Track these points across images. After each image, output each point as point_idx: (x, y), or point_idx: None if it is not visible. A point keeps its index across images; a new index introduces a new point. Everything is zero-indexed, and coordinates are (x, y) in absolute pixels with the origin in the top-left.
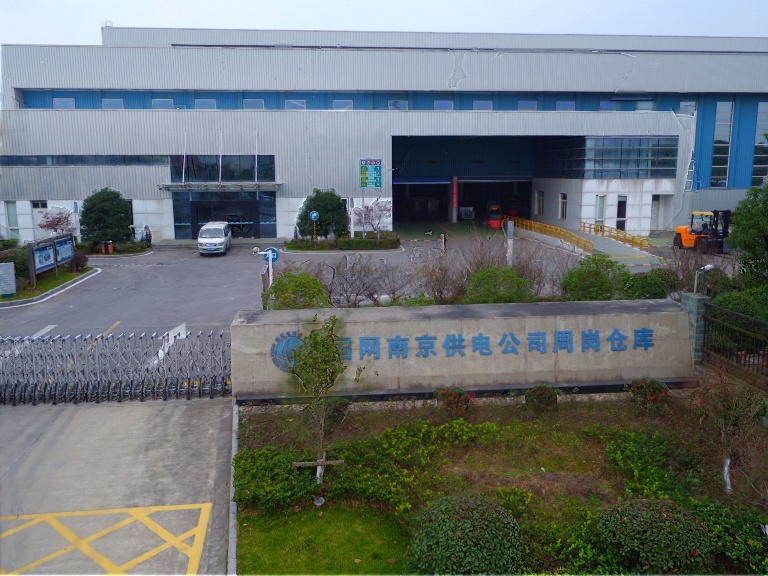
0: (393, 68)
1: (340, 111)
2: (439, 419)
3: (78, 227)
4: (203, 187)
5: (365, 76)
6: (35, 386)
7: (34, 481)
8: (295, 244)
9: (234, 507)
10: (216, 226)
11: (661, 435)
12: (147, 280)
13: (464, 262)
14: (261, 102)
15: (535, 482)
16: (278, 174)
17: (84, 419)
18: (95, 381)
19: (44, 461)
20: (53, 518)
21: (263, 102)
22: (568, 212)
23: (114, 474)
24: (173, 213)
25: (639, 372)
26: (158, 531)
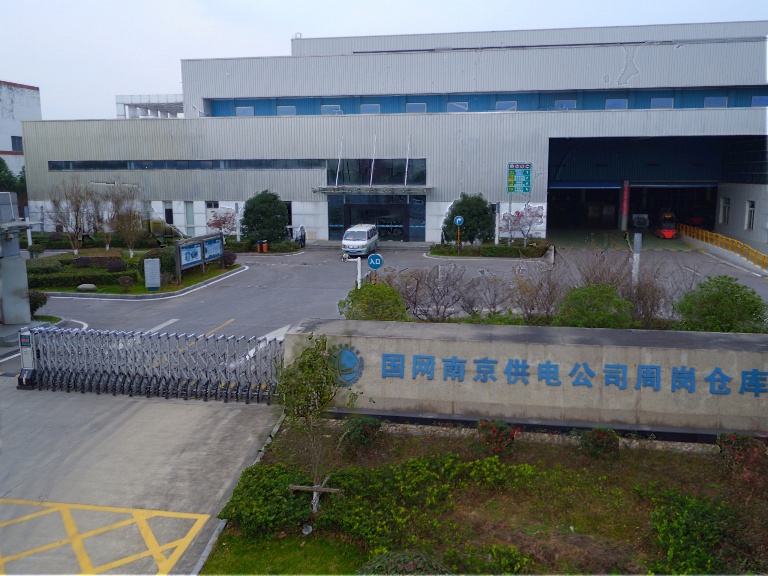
0: (561, 66)
1: (495, 113)
2: (473, 454)
3: (238, 226)
4: (355, 190)
5: (530, 76)
6: (117, 377)
7: (73, 470)
8: (438, 249)
9: (223, 523)
10: (360, 229)
11: (729, 507)
12: (282, 279)
13: (579, 277)
14: (424, 105)
15: (551, 543)
16: (429, 178)
17: (147, 413)
18: (168, 377)
19: (92, 451)
20: (68, 509)
21: (425, 105)
22: (755, 222)
23: (141, 472)
24: (328, 215)
25: (746, 422)
26: (147, 537)
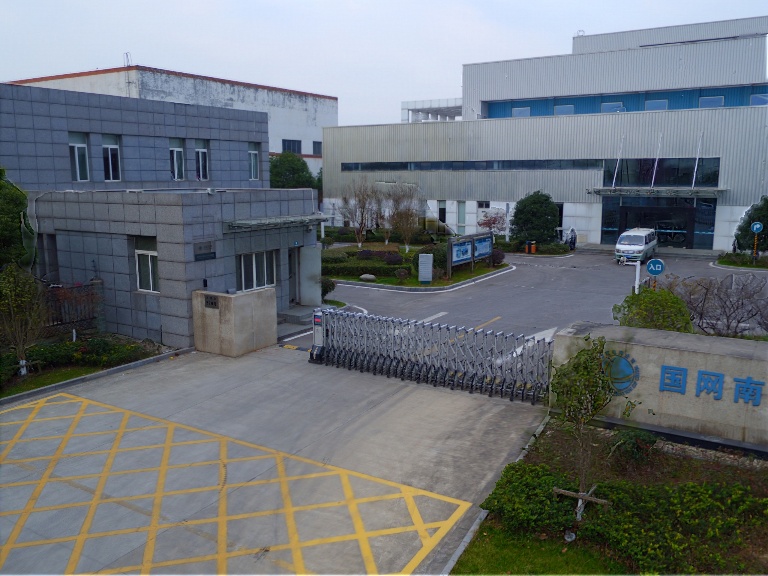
0: None
1: None
2: (767, 489)
3: (508, 227)
4: (634, 192)
5: None
6: (391, 361)
7: (351, 440)
8: (728, 258)
9: (485, 513)
10: (638, 233)
11: None
12: (550, 281)
13: None
14: (720, 99)
15: None
16: (722, 179)
17: (416, 398)
18: (437, 366)
19: (368, 425)
20: (346, 474)
21: (723, 99)
22: None
23: (410, 452)
24: (601, 217)
25: None
26: (413, 513)
